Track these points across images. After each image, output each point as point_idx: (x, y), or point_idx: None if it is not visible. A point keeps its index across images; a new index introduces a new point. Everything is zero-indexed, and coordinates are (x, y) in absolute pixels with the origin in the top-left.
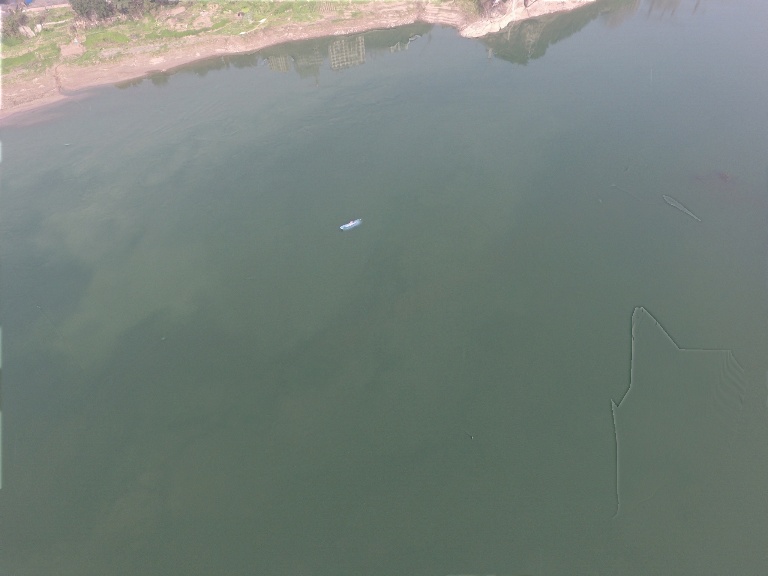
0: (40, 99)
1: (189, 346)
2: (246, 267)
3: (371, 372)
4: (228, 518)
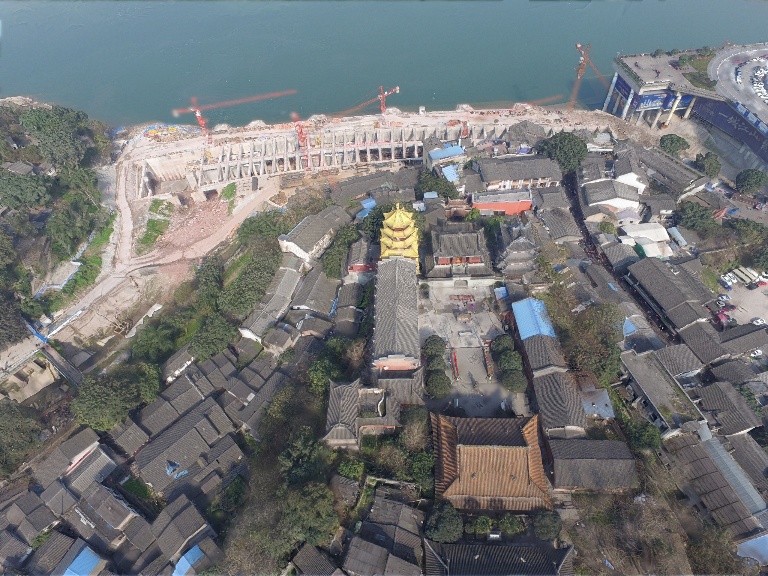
0: None
1: None
2: None
3: None
4: (447, 30)
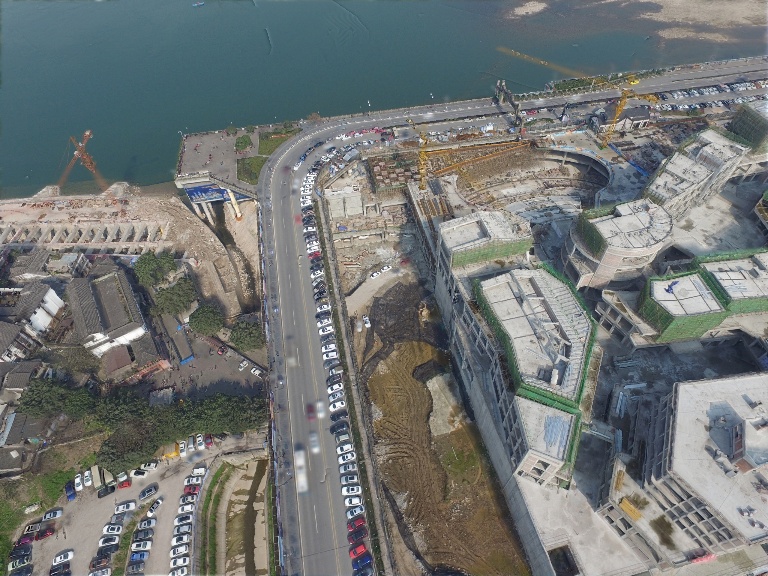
0: None
1: (104, 46)
2: (136, 23)
3: (194, 42)
4: (121, 80)
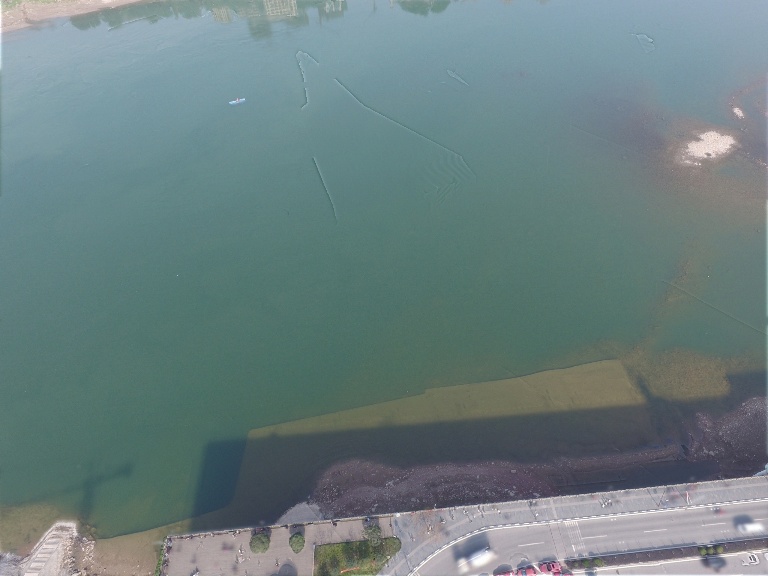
0: (10, 26)
1: (104, 168)
2: (154, 127)
3: (225, 177)
4: (114, 246)
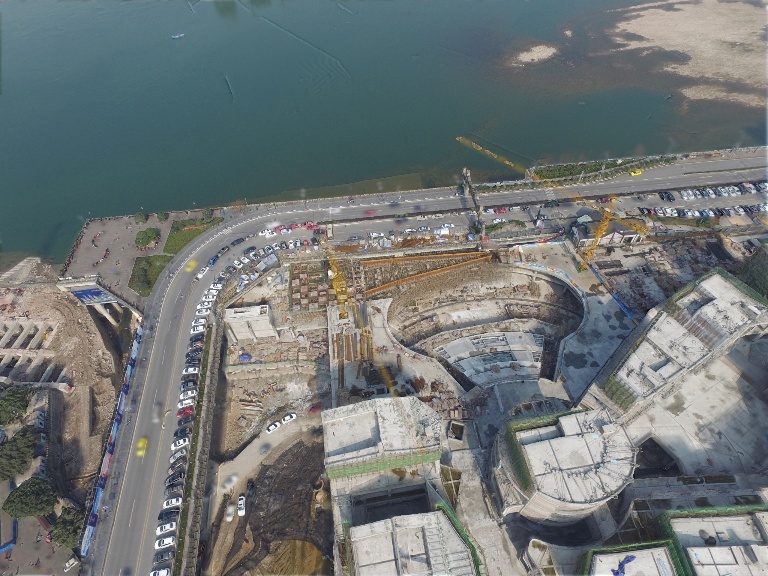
0: None
1: (71, 81)
2: (111, 55)
3: (162, 82)
4: (75, 125)
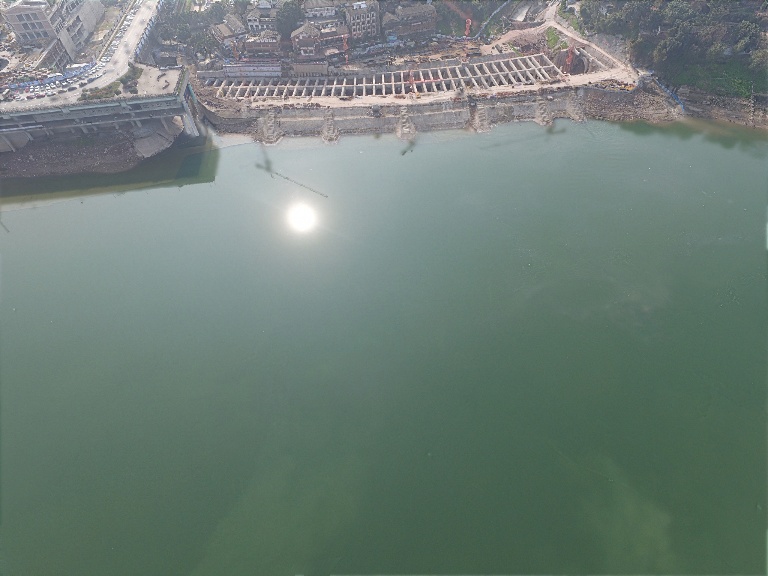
0: None
1: (394, 445)
2: None
3: (184, 413)
4: (314, 303)
